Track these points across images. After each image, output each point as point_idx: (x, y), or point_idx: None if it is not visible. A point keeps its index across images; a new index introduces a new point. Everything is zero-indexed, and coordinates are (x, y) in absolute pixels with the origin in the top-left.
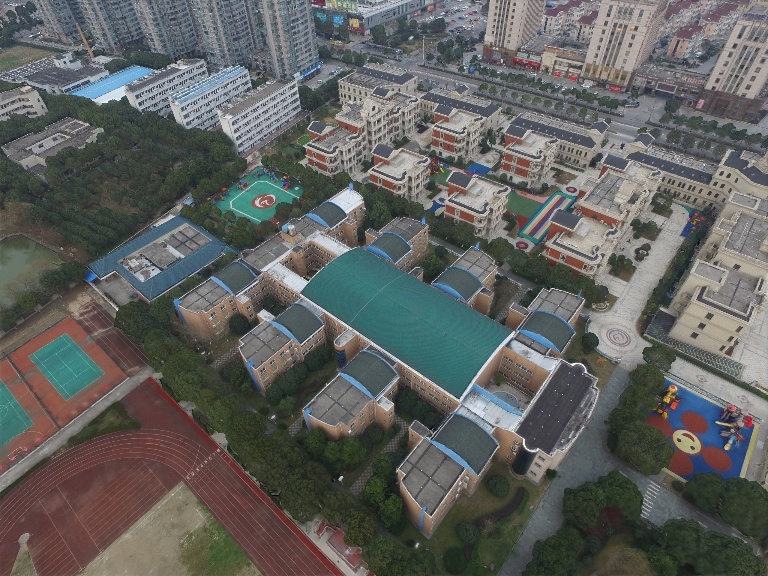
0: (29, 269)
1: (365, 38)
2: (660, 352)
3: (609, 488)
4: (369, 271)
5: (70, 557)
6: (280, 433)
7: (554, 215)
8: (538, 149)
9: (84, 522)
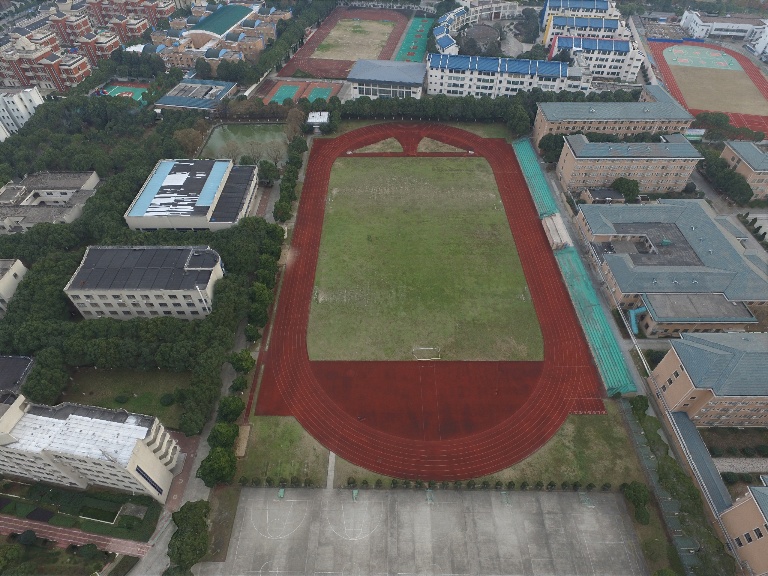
0: (238, 106)
1: None
2: (213, 1)
3: (266, 3)
4: None
5: None
6: (283, 33)
7: None
8: (74, 17)
9: (334, 65)
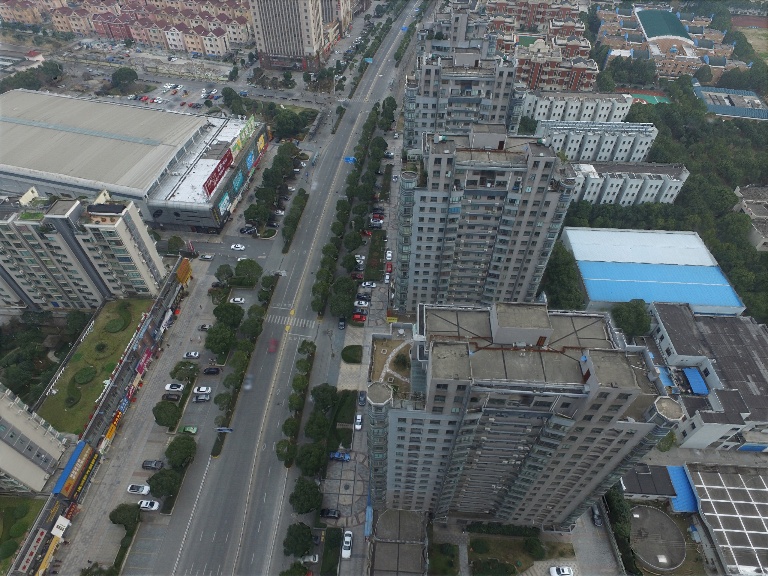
0: None
1: (274, 148)
2: None
3: None
4: (661, 30)
5: None
6: None
7: (570, 5)
8: None
9: None
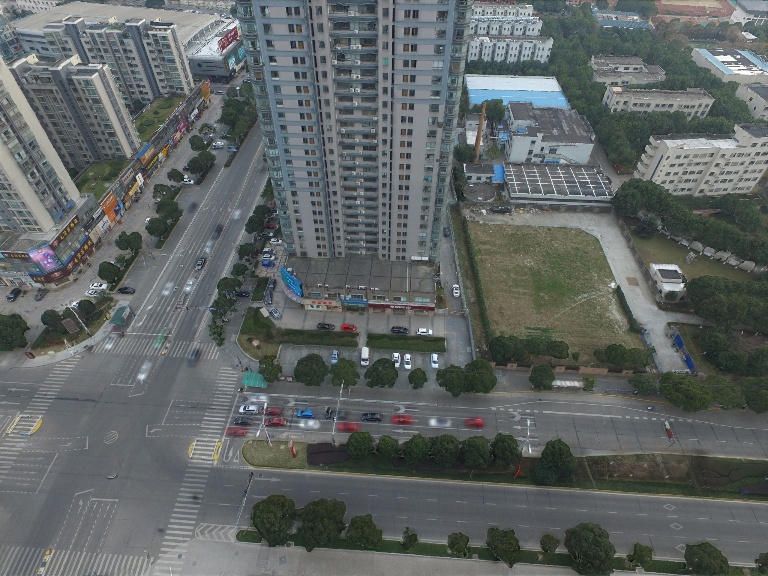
0: (682, 25)
1: None
2: None
3: None
4: None
5: (697, 7)
6: None
7: None
8: None
9: (691, 8)
